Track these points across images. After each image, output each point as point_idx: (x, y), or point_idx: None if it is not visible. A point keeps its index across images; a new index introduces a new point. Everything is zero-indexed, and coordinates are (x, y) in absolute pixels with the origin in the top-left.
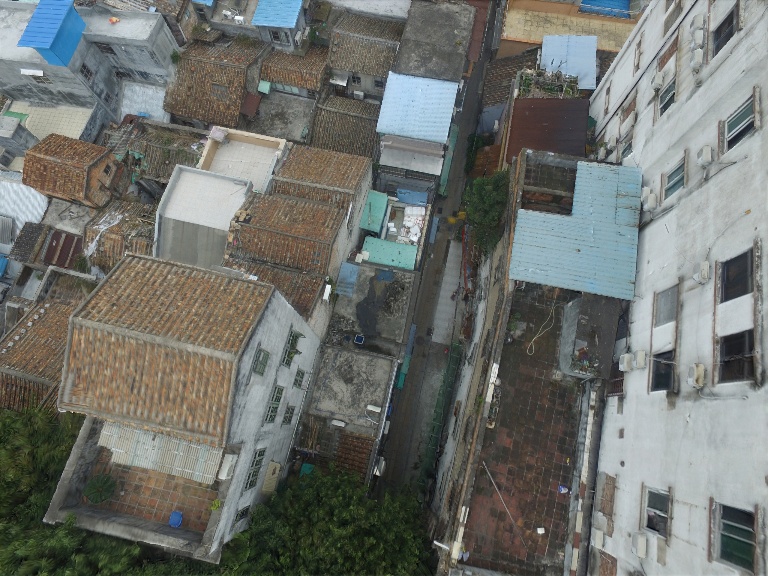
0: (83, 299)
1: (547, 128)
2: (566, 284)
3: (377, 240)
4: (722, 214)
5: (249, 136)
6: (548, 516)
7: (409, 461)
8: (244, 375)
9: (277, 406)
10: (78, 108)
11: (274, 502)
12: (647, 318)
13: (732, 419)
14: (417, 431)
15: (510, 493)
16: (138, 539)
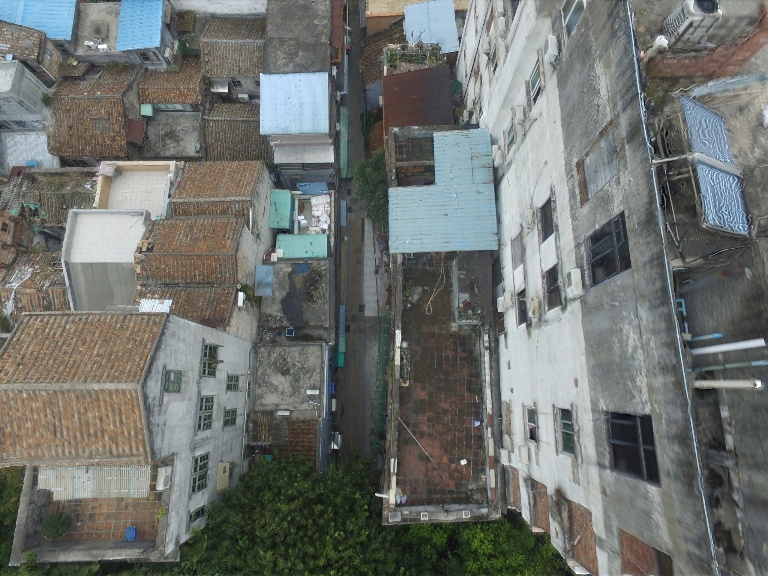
0: None
1: (416, 100)
2: (439, 247)
3: (288, 236)
4: (535, 166)
5: (138, 165)
6: (468, 448)
7: (366, 429)
8: (154, 398)
9: (210, 413)
10: None
11: (229, 497)
12: (510, 263)
13: (556, 339)
14: (368, 400)
15: (432, 437)
16: (98, 559)
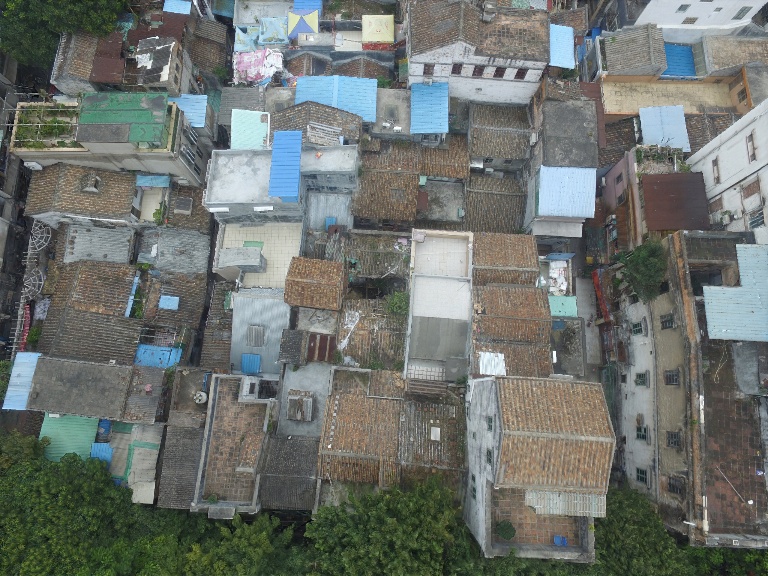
0: (359, 387)
1: (674, 199)
2: (750, 338)
3: None
4: None
5: (443, 234)
6: (753, 492)
7: None
8: None
9: None
10: (282, 223)
11: None
12: None
13: None
14: None
15: (725, 481)
16: (549, 557)
